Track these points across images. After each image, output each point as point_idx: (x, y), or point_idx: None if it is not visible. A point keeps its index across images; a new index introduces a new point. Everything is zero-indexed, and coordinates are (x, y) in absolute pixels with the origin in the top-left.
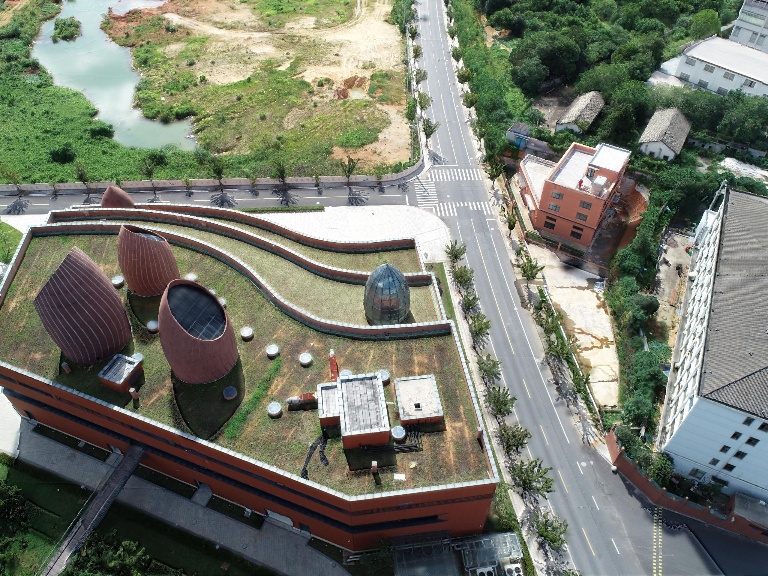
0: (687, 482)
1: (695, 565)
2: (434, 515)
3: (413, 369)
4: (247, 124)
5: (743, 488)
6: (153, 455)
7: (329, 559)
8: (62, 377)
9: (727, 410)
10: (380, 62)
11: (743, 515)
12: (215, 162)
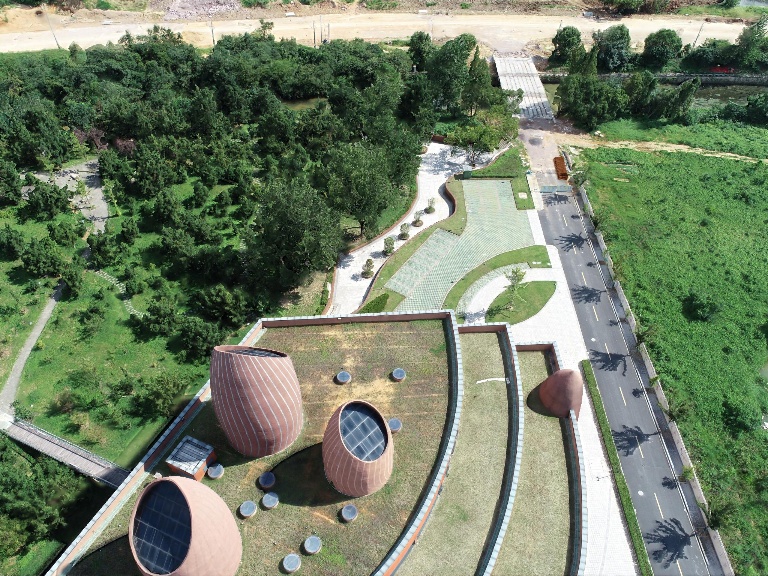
0: None
1: None
2: None
3: None
4: None
5: None
6: None
7: None
8: None
9: None
10: None
11: None
12: (728, 510)
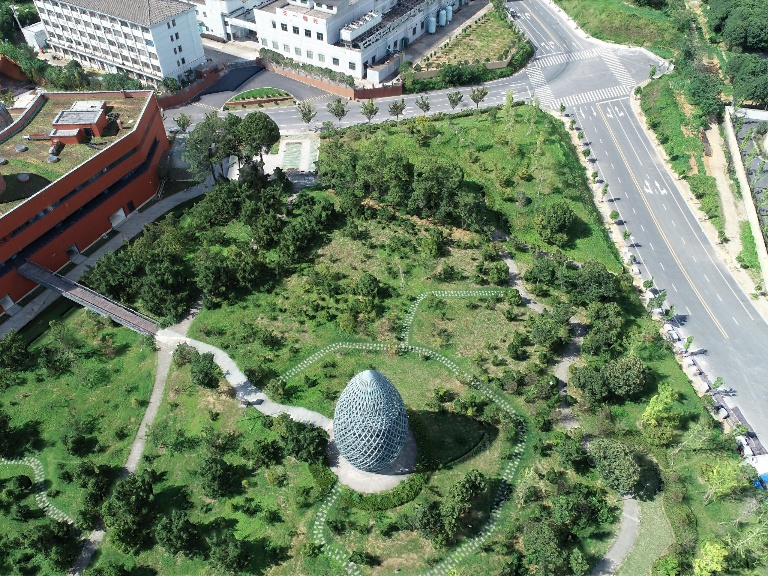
0: (183, 80)
1: (218, 98)
2: (155, 142)
3: None
4: None
5: (194, 67)
6: (34, 257)
7: (154, 204)
8: None
9: (160, 26)
10: None
11: (205, 70)
12: None
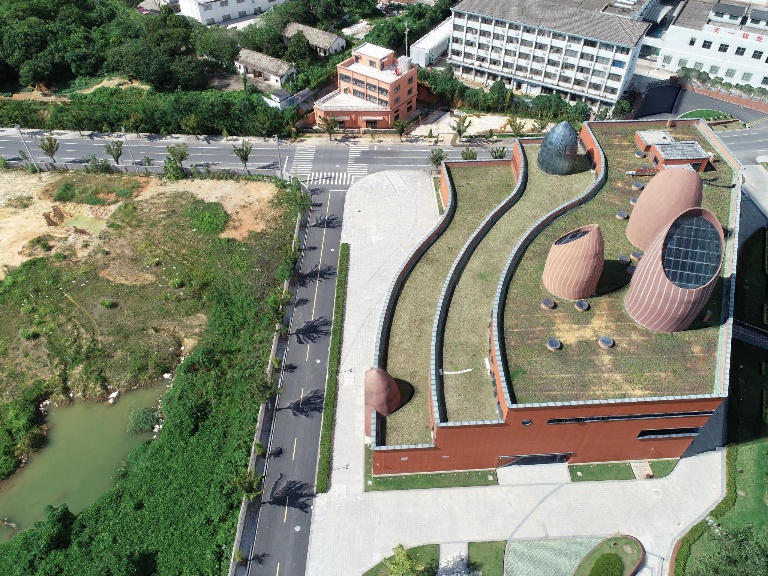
0: None
1: None
2: None
3: (626, 144)
4: (121, 322)
5: (627, 88)
6: None
7: None
8: (712, 324)
9: None
10: (19, 192)
11: (643, 91)
12: None
